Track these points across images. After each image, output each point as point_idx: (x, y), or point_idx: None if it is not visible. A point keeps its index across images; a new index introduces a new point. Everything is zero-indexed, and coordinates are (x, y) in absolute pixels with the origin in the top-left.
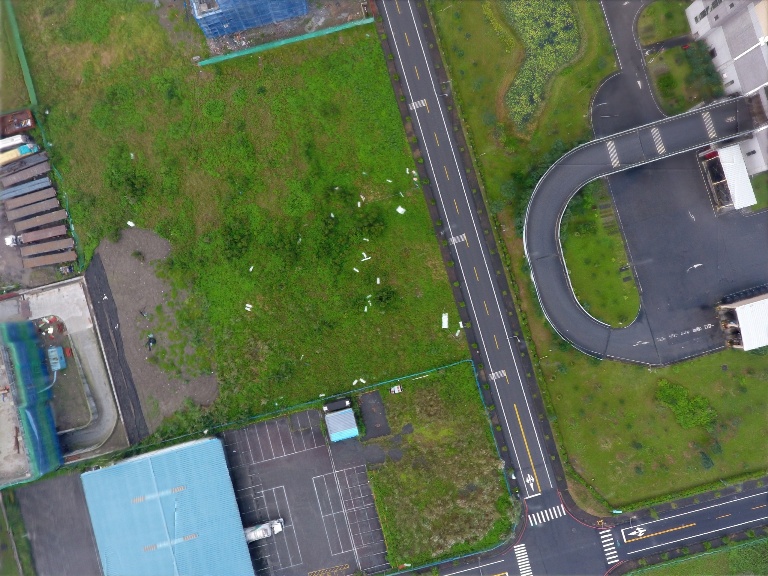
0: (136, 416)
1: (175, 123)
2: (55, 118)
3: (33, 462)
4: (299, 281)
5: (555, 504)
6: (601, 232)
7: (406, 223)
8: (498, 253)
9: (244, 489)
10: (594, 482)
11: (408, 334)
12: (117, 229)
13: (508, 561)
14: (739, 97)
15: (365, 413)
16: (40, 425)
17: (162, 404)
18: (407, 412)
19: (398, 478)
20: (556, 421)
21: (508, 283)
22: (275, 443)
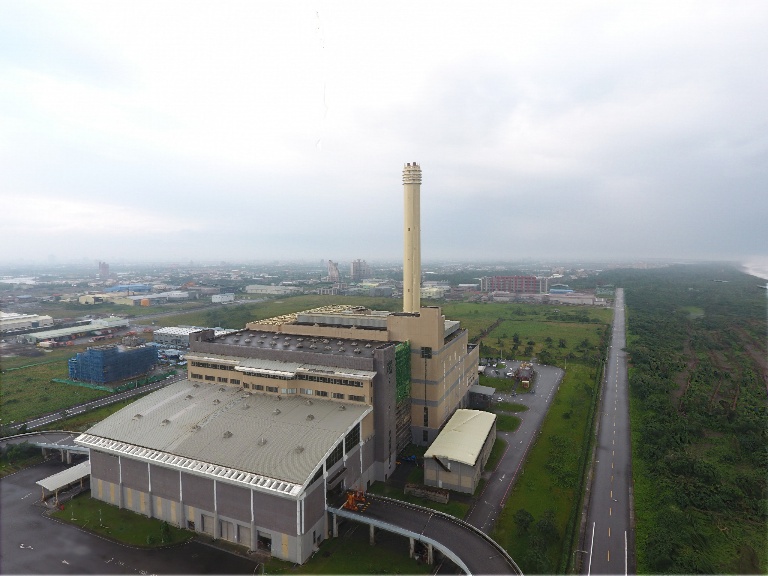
0: None
1: None
2: (1, 373)
3: None
4: None
5: None
6: None
7: None
8: None
9: None
10: None
11: None
12: None
13: None
14: None
15: None
16: None
17: None
18: None
19: None
20: None
21: None
22: None
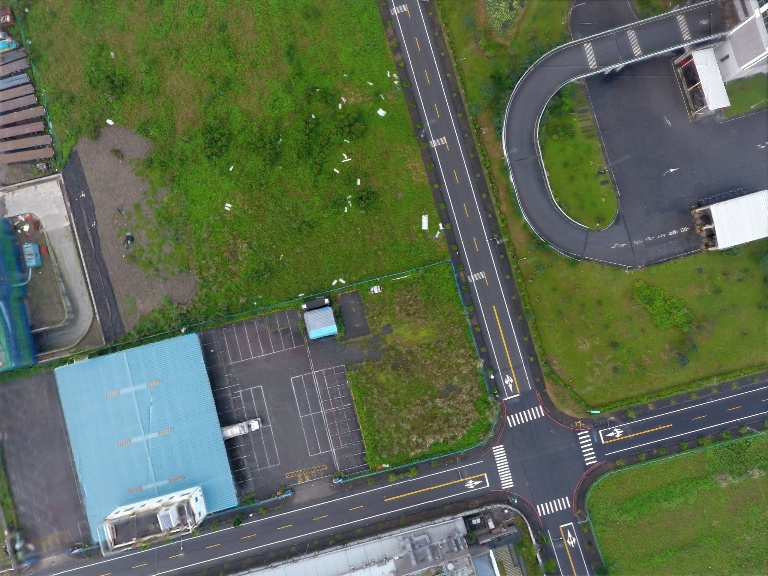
0: (112, 314)
1: (156, 23)
2: (35, 16)
3: (5, 352)
4: (279, 181)
5: (534, 405)
6: (579, 136)
7: (387, 125)
8: (478, 156)
9: (221, 389)
10: (572, 383)
11: (388, 235)
12: (96, 127)
13: (487, 462)
14: (712, 0)
15: (344, 313)
16: (13, 319)
17: (139, 302)
18: (386, 312)
19: (377, 378)
20: (535, 322)
21: (488, 186)
22: (253, 343)
